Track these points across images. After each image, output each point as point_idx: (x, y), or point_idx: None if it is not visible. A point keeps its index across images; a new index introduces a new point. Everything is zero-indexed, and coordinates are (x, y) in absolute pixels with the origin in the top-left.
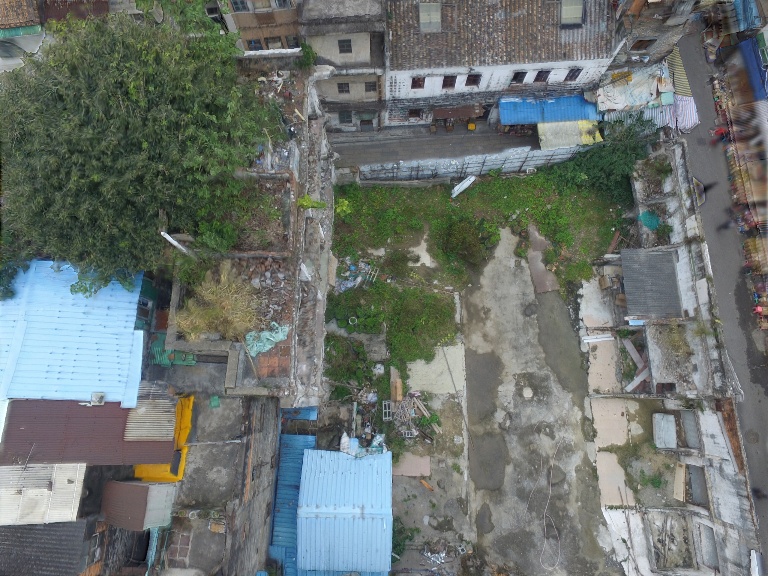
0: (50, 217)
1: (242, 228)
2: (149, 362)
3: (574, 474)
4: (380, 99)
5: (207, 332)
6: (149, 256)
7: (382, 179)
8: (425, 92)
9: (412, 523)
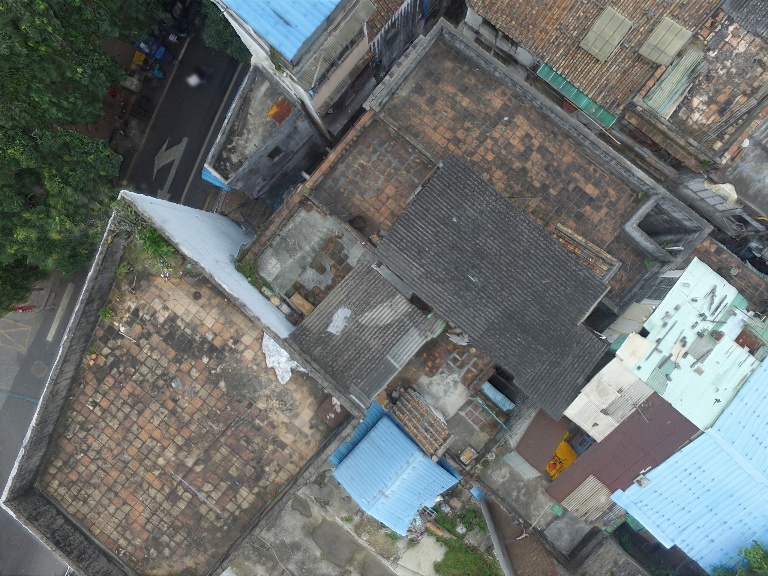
0: None
1: None
2: None
3: None
4: None
5: None
6: None
7: None
8: None
9: None
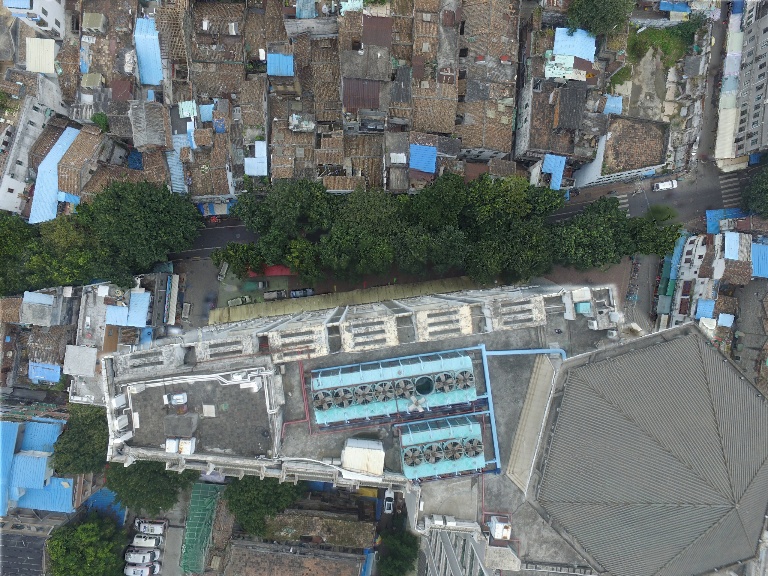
0: None
1: None
2: None
3: None
4: None
5: None
6: (608, 30)
7: None
8: None
9: None
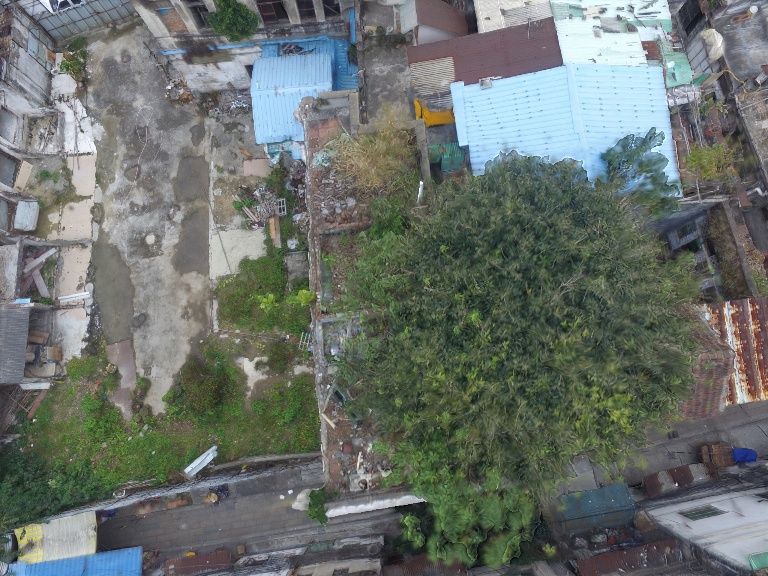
0: None
1: None
2: None
3: (117, 176)
4: (296, 568)
5: None
6: None
7: None
8: None
9: None
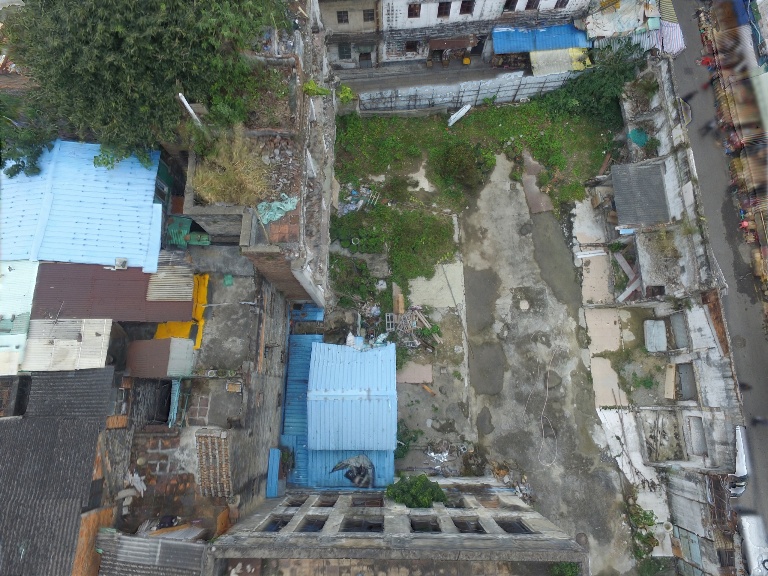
0: (78, 72)
1: (252, 111)
2: (166, 242)
3: (570, 379)
4: (378, 30)
5: (222, 201)
6: (167, 125)
7: (381, 110)
8: (421, 22)
9: (416, 426)
